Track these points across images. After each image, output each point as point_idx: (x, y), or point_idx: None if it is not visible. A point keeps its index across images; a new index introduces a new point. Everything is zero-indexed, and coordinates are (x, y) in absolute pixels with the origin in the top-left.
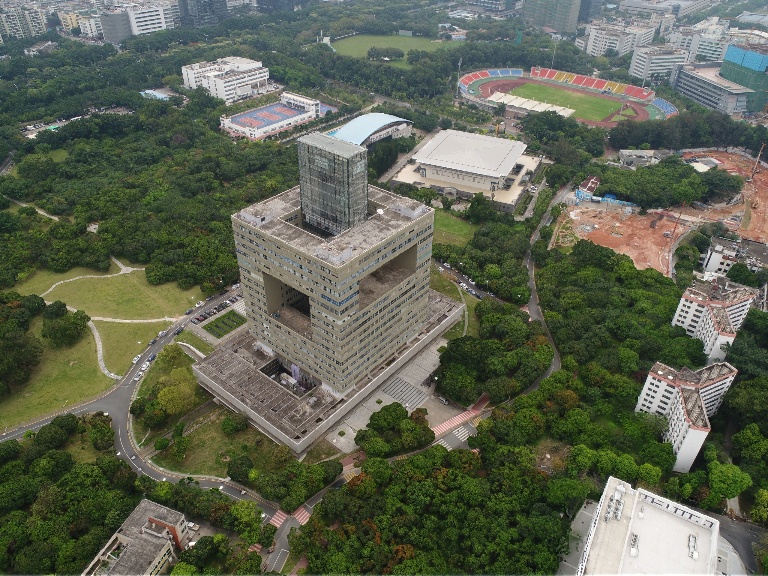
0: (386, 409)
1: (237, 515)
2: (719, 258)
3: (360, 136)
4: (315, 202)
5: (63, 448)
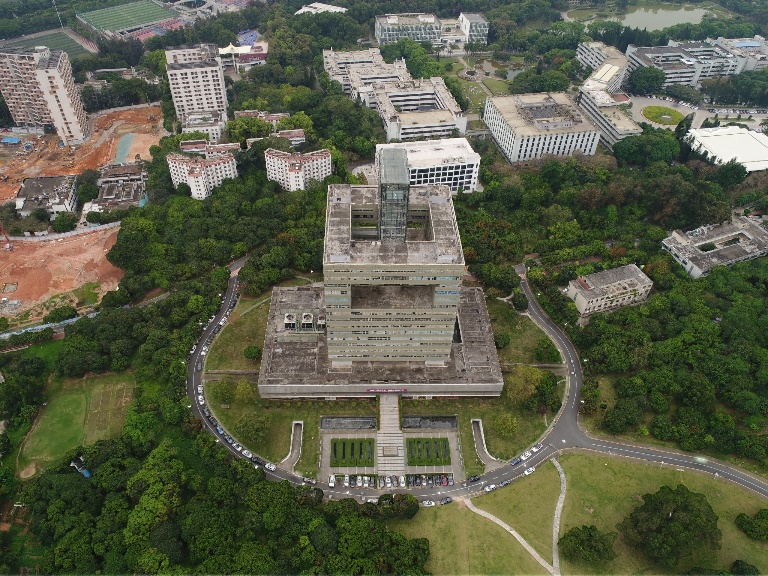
0: None
1: None
2: (67, 203)
3: None
4: None
5: None
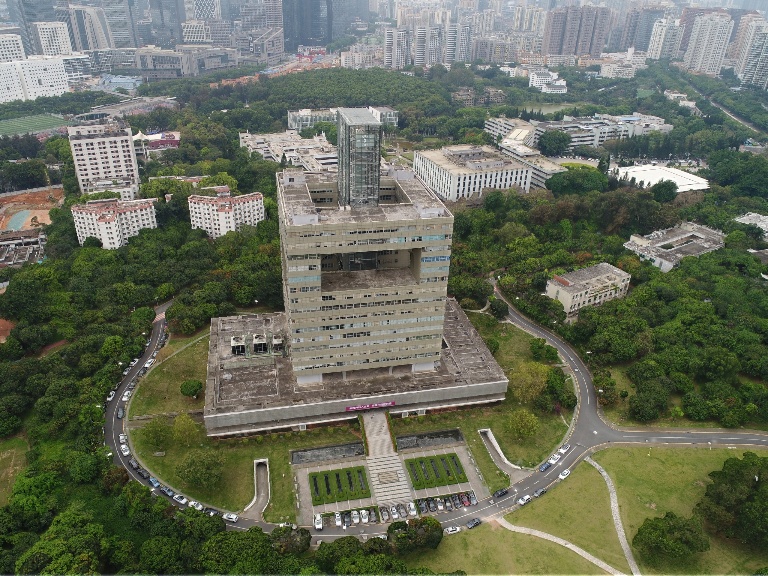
0: None
1: None
2: None
3: None
4: None
5: None
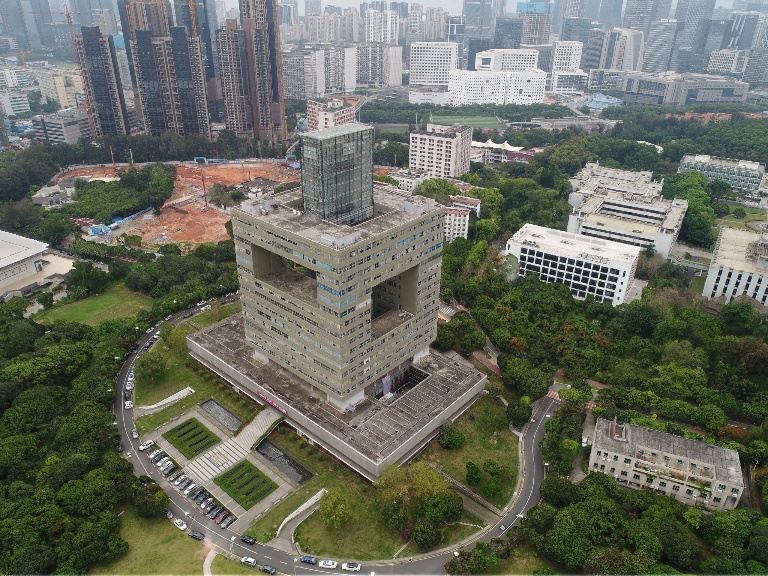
0: None
1: (577, 398)
2: None
3: None
4: (341, 200)
5: None
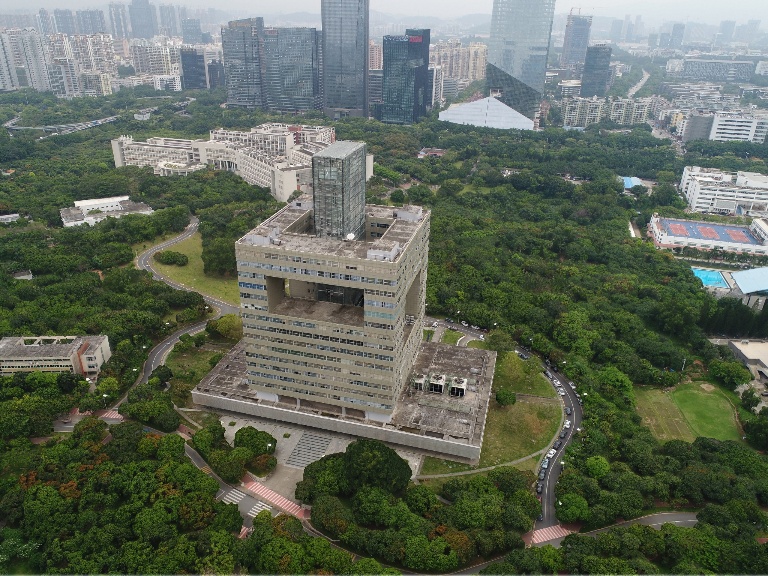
0: (258, 432)
1: None
2: None
3: (764, 284)
4: None
5: (178, 309)
